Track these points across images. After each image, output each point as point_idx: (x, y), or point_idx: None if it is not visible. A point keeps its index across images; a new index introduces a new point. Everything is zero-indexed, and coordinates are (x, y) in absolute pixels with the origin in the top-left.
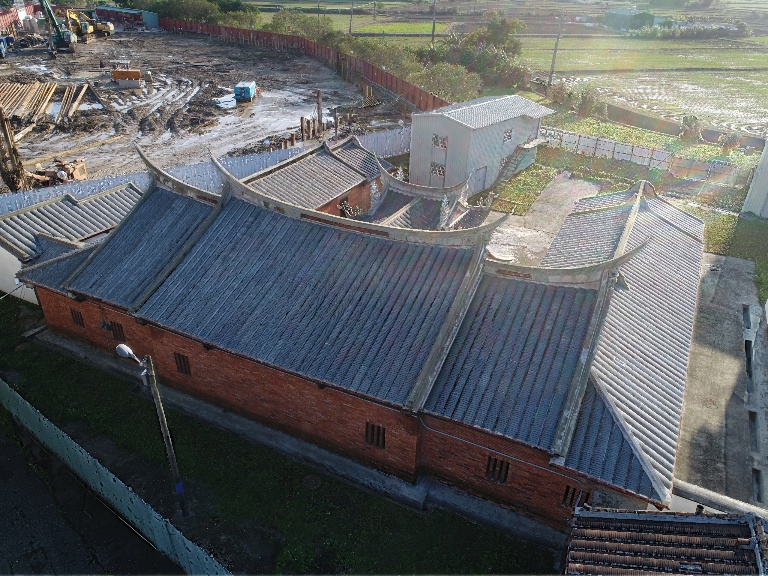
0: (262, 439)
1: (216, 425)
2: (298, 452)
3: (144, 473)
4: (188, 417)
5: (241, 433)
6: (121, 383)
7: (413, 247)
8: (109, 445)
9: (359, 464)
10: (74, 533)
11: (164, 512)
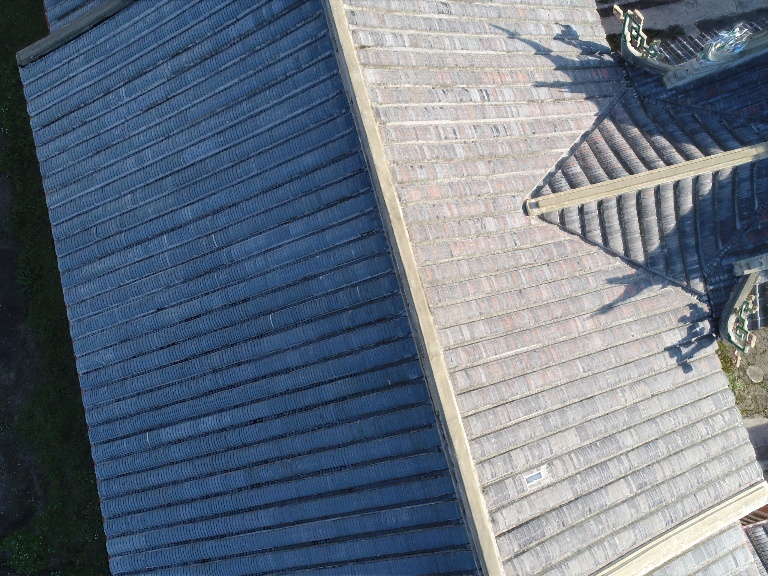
0: None
1: None
2: None
3: (0, 284)
4: None
5: None
6: None
7: (428, 443)
8: (3, 203)
9: None
10: None
11: None
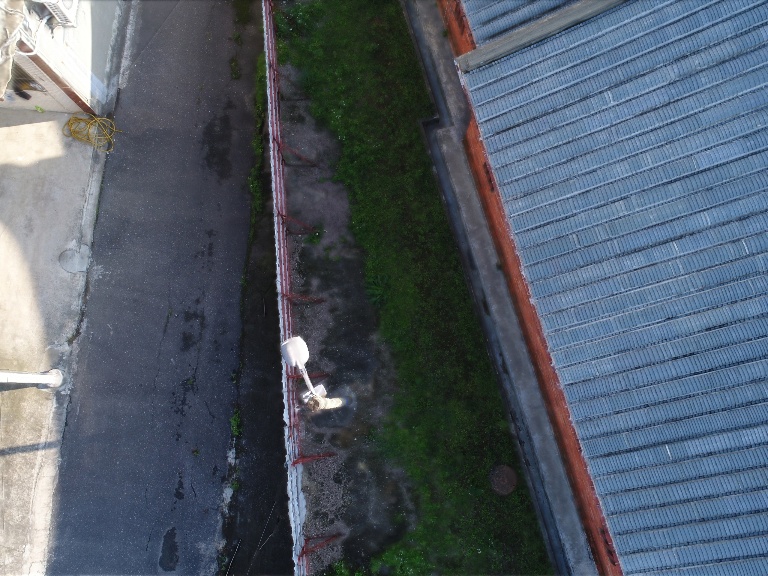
0: (505, 355)
1: (477, 273)
2: (526, 419)
3: (349, 294)
4: (452, 238)
5: (492, 317)
6: (421, 98)
7: None
8: (342, 211)
9: (576, 509)
10: (239, 324)
11: (331, 375)
